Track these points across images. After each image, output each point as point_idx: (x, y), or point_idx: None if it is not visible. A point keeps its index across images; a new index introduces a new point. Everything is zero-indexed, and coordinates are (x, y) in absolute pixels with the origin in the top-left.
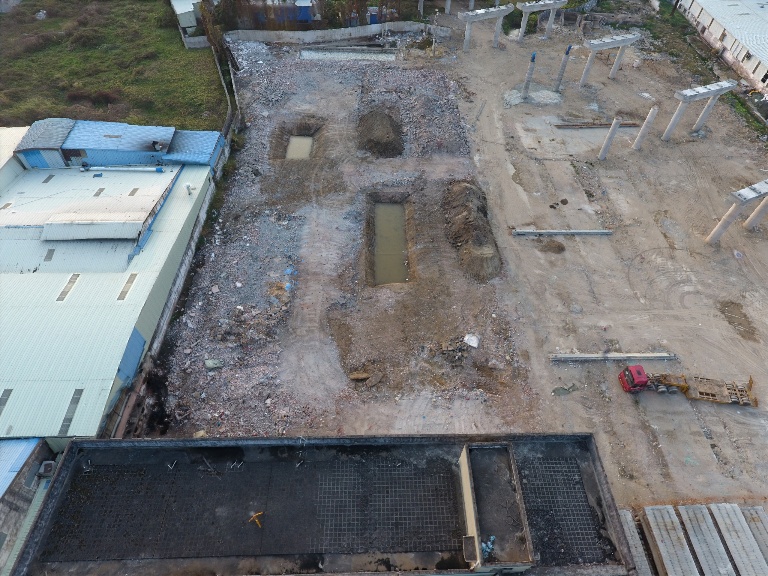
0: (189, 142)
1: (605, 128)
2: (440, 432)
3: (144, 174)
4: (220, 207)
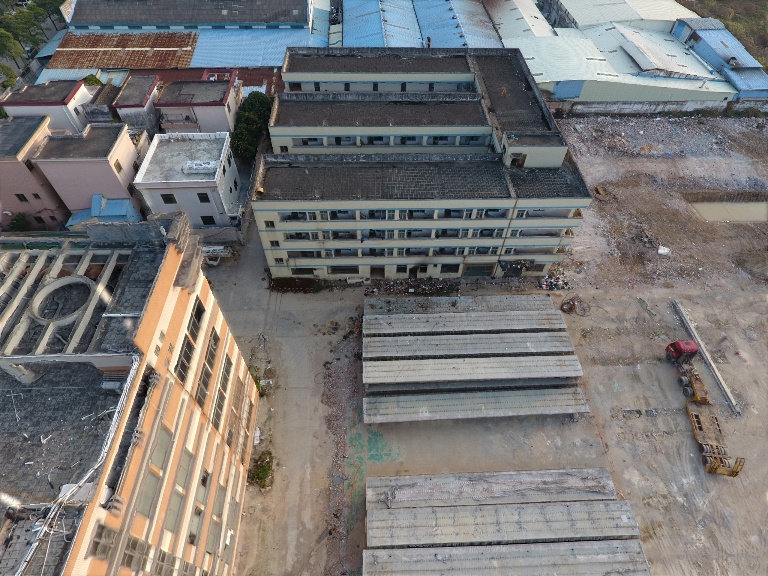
0: (754, 77)
1: None
2: (576, 228)
3: (703, 68)
4: (707, 117)
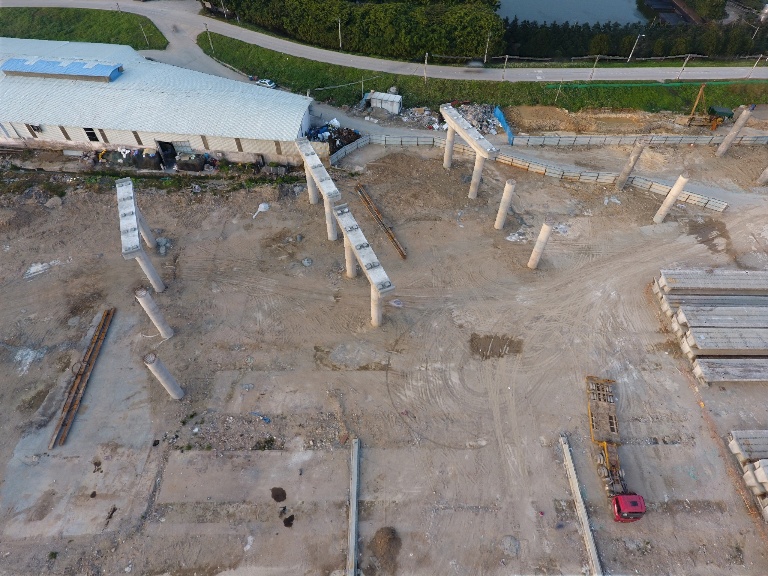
0: None
1: (99, 360)
2: None
3: None
4: None
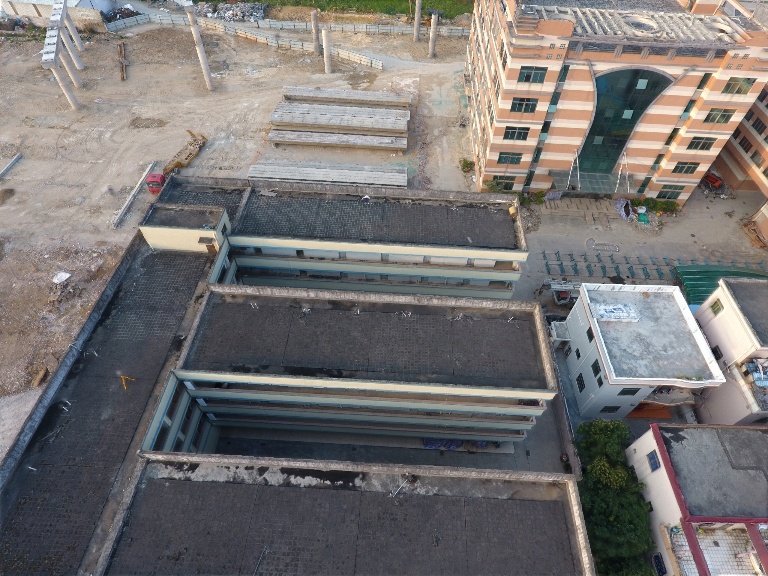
0: None
1: None
2: None
3: None
4: None
